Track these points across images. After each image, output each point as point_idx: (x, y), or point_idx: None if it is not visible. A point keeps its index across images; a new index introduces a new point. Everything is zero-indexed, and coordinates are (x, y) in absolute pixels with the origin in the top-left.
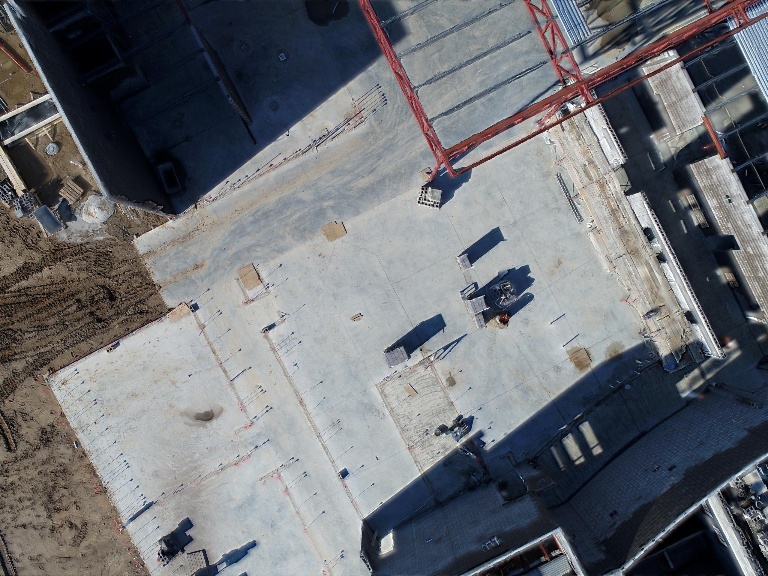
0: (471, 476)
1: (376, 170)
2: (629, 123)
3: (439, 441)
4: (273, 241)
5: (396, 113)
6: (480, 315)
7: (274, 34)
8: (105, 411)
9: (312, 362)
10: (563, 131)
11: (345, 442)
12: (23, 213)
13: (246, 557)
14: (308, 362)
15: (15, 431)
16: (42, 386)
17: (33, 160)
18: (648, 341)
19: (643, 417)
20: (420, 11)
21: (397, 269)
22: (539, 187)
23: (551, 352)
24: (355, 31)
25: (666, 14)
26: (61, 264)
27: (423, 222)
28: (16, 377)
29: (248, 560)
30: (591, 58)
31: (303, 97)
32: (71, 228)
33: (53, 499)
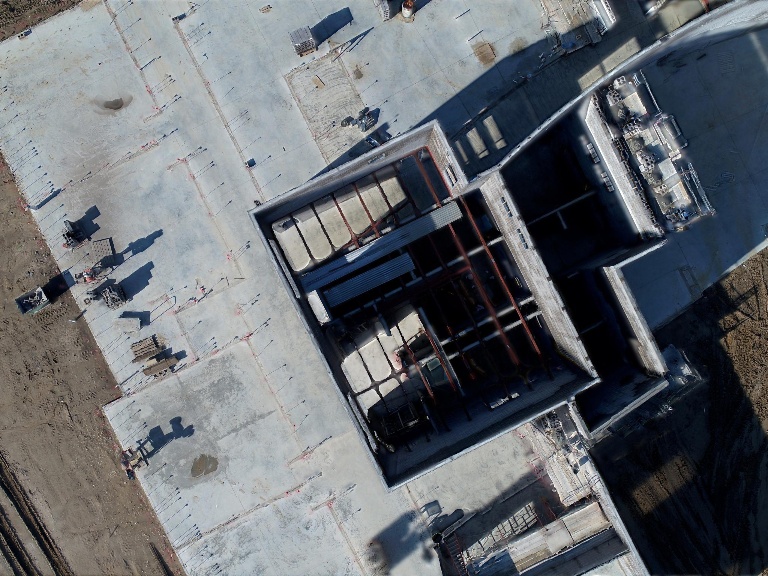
0: None
1: None
2: None
3: (345, 133)
4: None
5: None
6: None
7: None
8: (15, 98)
9: (221, 53)
10: None
11: (253, 132)
12: None
13: (152, 246)
14: (217, 53)
15: None
16: None
17: None
18: (549, 32)
19: (546, 112)
20: None
21: None
22: None
23: (456, 47)
24: None
25: None
26: None
27: None
28: None
29: (154, 249)
30: None
31: None
32: None
33: None
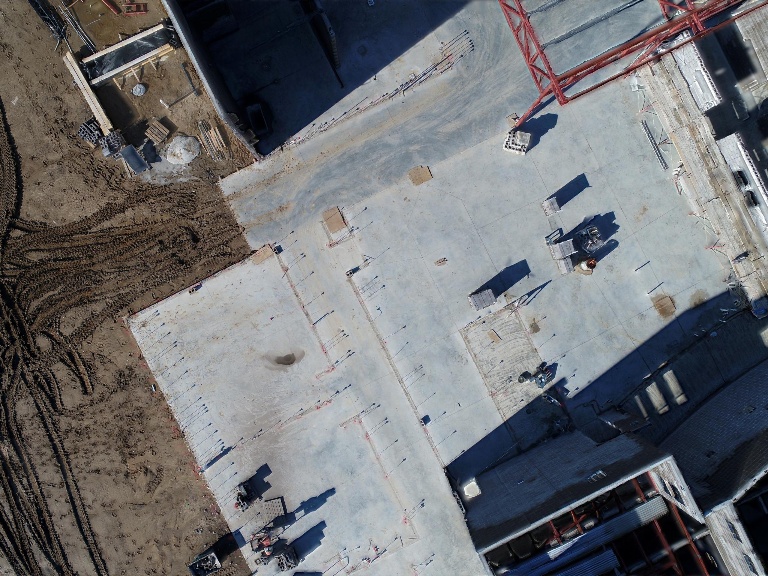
0: (556, 423)
1: (462, 115)
2: (714, 72)
3: (522, 388)
4: (358, 184)
5: (483, 59)
6: (568, 258)
7: None
8: (185, 354)
9: (395, 306)
10: (653, 75)
11: (427, 388)
12: (110, 151)
13: (325, 505)
14: (391, 306)
15: (92, 373)
16: (121, 328)
17: (119, 101)
18: (734, 289)
19: (728, 366)
20: None
21: (482, 214)
22: (624, 134)
23: (636, 299)
24: None
25: None
26: (144, 205)
27: (509, 167)
28: (95, 318)
29: (327, 508)
30: (676, 8)
31: (391, 42)
32: (155, 169)
33: (129, 444)
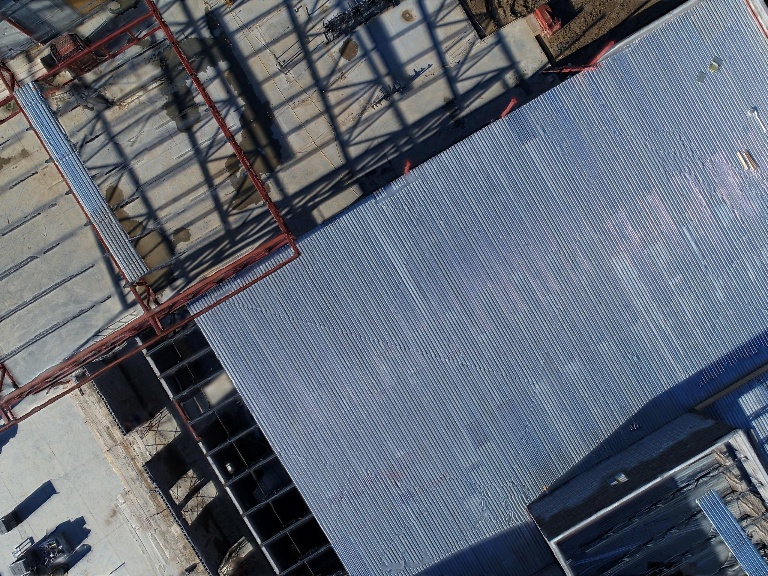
0: None
1: None
2: None
3: None
4: None
5: None
6: None
7: None
8: None
9: None
10: (82, 395)
11: None
12: None
13: None
14: None
15: None
16: None
17: None
18: None
19: None
20: None
21: None
22: (87, 438)
23: None
24: None
25: (202, 258)
26: None
27: None
28: None
29: None
30: (129, 306)
31: None
32: None
33: None
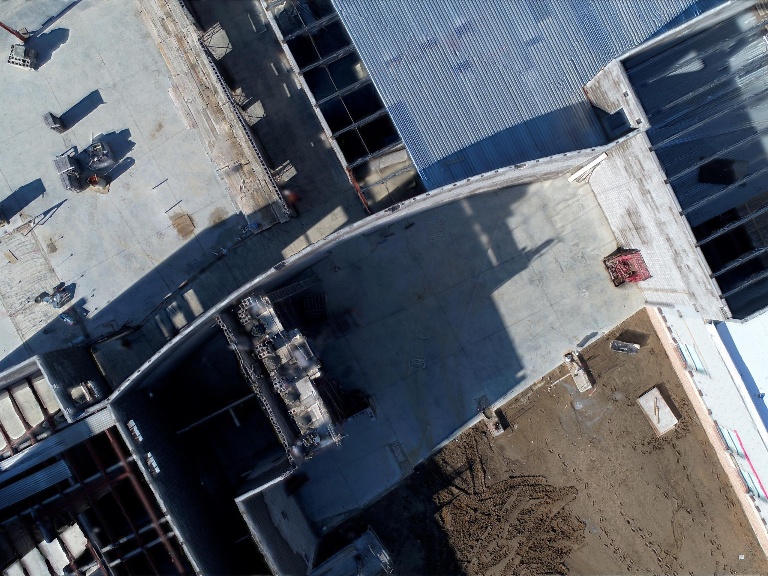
0: (69, 343)
1: None
2: None
3: (41, 309)
4: None
5: None
6: (64, 175)
7: None
8: None
9: None
10: None
11: None
12: None
13: None
14: None
15: None
16: None
17: None
18: None
19: None
20: None
21: None
22: (138, 49)
23: (154, 218)
24: None
25: None
26: None
27: (20, 84)
28: None
29: None
30: None
31: None
32: None
33: None
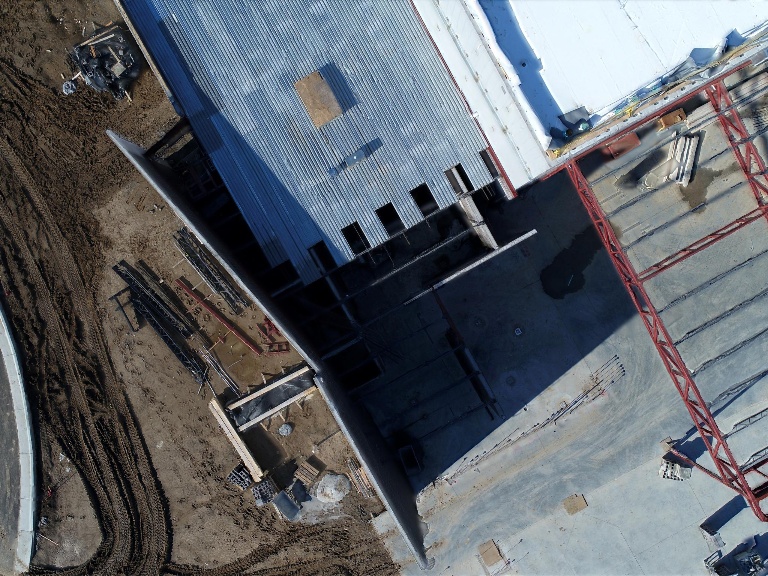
0: None
1: (616, 441)
2: None
3: None
4: (513, 516)
5: (635, 384)
6: None
7: (509, 309)
8: None
9: None
10: None
11: None
12: (263, 502)
13: None
14: None
15: None
16: None
17: (266, 441)
18: None
19: None
20: (657, 280)
21: (639, 540)
22: None
23: None
24: (591, 303)
25: None
26: (297, 545)
27: (665, 492)
28: None
29: None
30: None
31: (540, 371)
32: (306, 508)
33: None
